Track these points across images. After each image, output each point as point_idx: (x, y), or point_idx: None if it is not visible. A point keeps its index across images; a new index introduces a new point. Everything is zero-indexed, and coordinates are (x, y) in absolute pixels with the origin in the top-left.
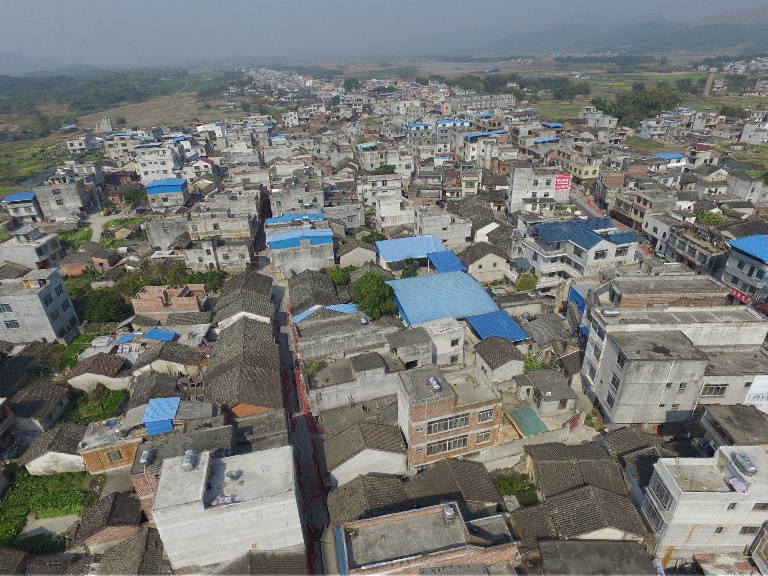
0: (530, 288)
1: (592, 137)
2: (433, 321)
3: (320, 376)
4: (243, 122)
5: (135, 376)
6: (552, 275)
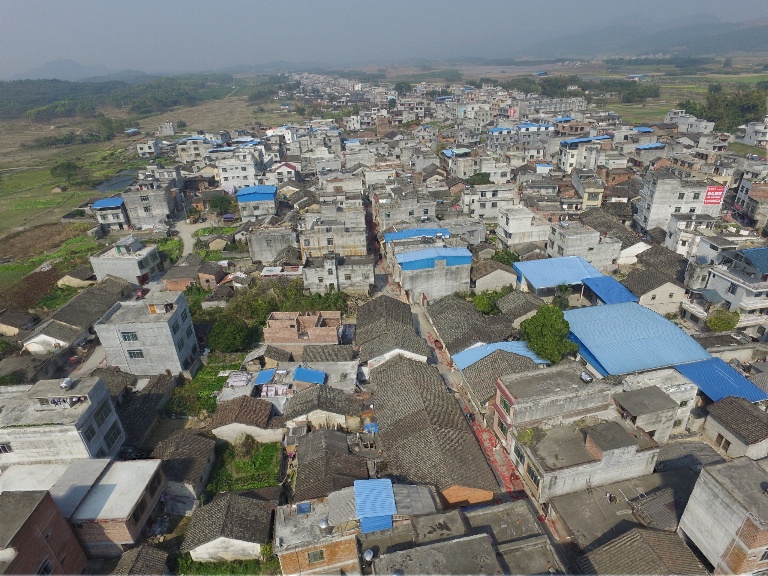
0: (731, 328)
1: (691, 143)
2: (650, 374)
3: (544, 450)
4: (310, 126)
5: (289, 428)
6: (752, 311)
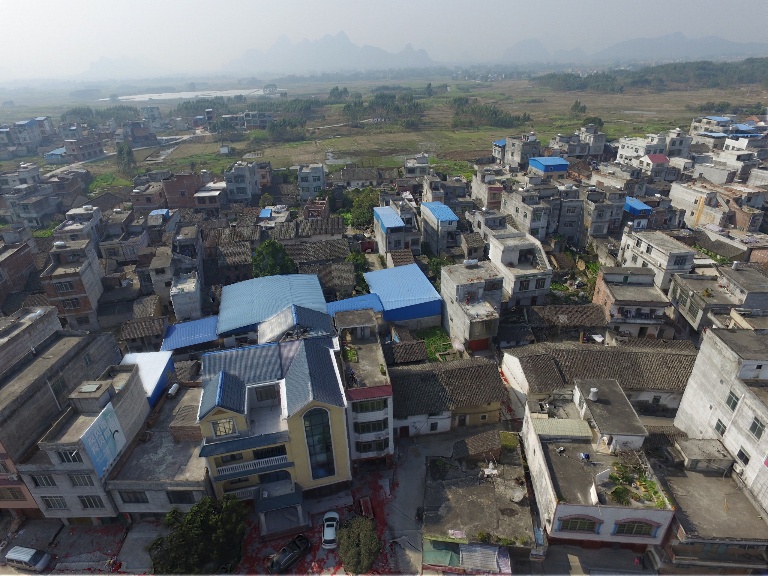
0: None
1: None
2: None
3: None
4: None
5: None
6: None
